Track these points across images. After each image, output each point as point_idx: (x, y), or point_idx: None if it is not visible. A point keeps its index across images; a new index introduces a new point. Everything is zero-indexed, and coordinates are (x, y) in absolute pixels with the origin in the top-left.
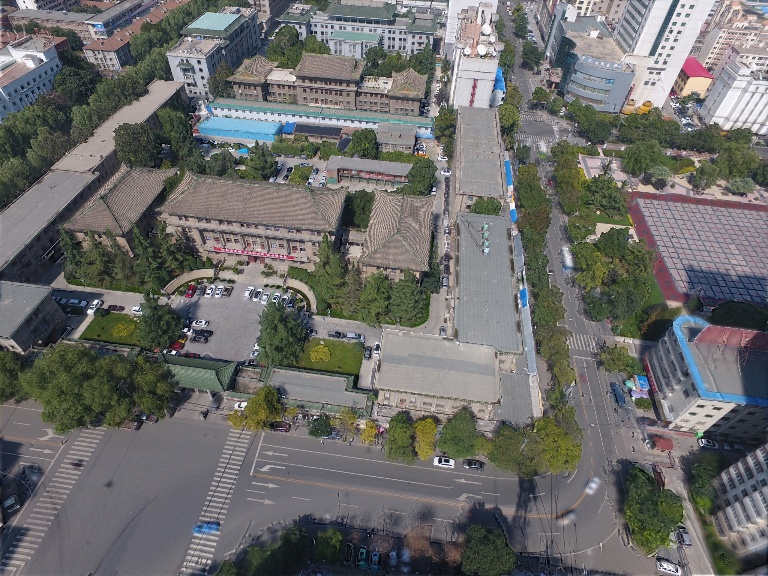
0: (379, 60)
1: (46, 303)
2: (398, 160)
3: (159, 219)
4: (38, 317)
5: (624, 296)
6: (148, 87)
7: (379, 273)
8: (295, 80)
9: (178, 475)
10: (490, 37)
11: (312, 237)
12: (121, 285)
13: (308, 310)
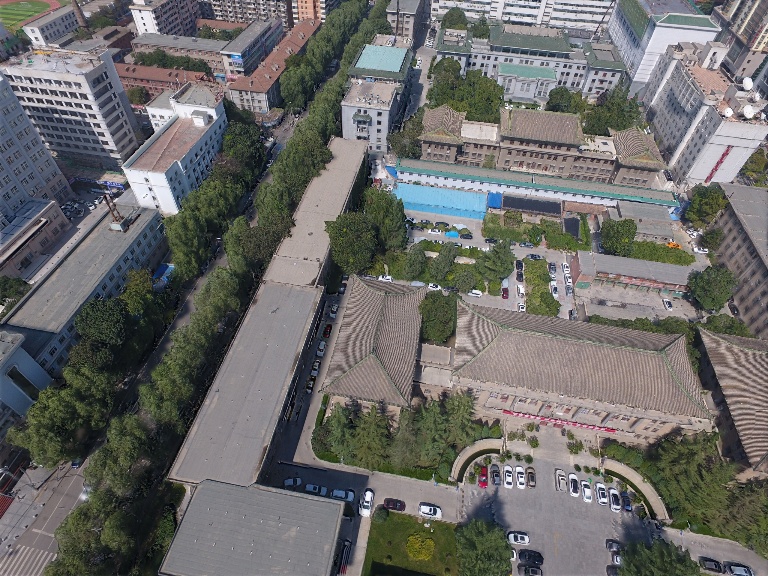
0: (564, 103)
1: None
2: (654, 255)
3: (422, 364)
4: None
5: None
6: (329, 148)
7: None
8: (496, 138)
9: None
10: (750, 93)
11: (662, 416)
12: (391, 465)
13: (652, 516)
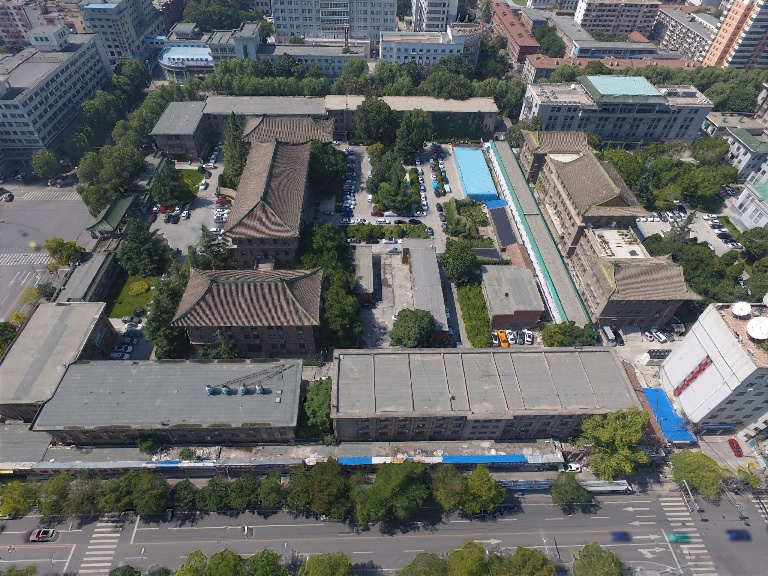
0: (751, 249)
1: (187, 139)
2: (465, 307)
3: None
4: (176, 141)
5: None
6: (475, 98)
7: (171, 284)
8: None
9: (52, 237)
10: None
11: None
12: None
13: None
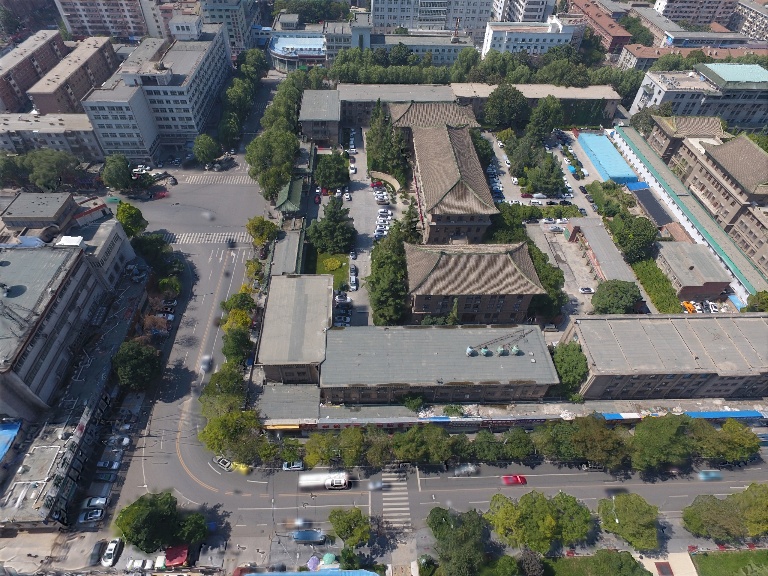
0: None
1: (332, 125)
2: (649, 281)
3: None
4: (322, 127)
5: (454, 541)
6: (594, 86)
7: (393, 257)
8: None
9: (230, 218)
10: None
11: None
12: None
13: None
